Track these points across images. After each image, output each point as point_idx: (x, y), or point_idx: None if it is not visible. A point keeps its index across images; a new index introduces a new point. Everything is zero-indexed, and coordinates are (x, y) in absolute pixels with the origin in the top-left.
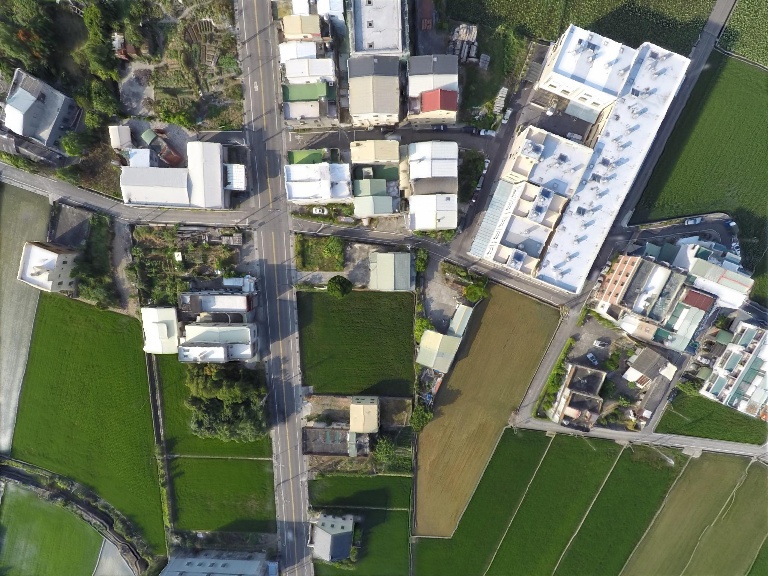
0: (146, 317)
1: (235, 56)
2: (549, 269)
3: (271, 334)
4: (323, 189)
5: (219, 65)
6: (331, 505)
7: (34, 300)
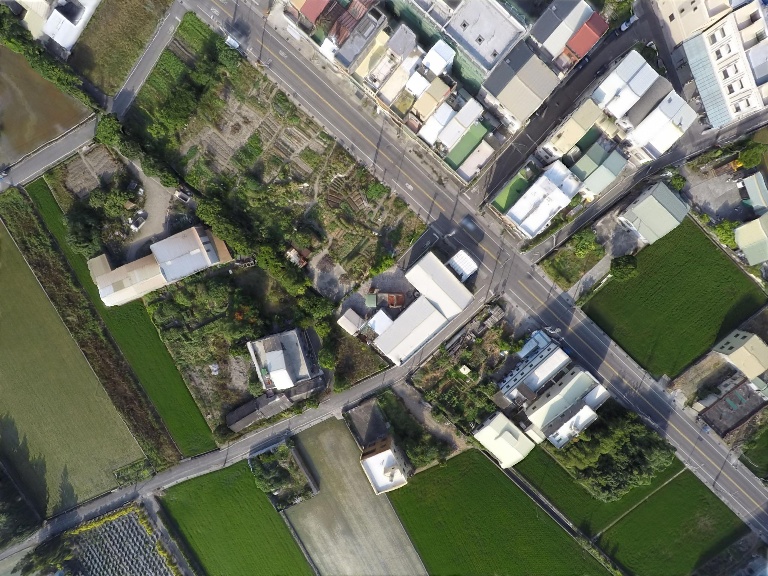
0: (484, 440)
1: (376, 182)
2: None
3: (590, 363)
4: (559, 199)
5: (370, 200)
6: None
7: (385, 503)
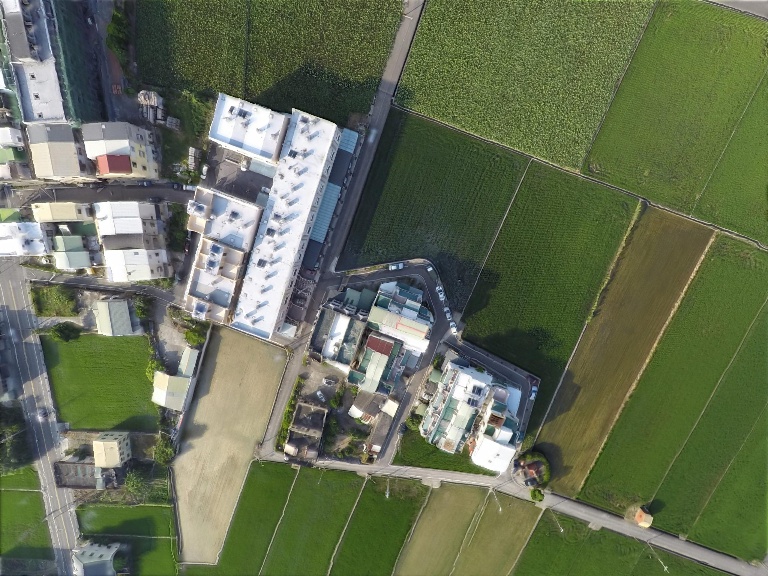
0: None
1: None
2: (243, 317)
3: (22, 375)
4: (16, 247)
5: None
6: (101, 533)
7: None
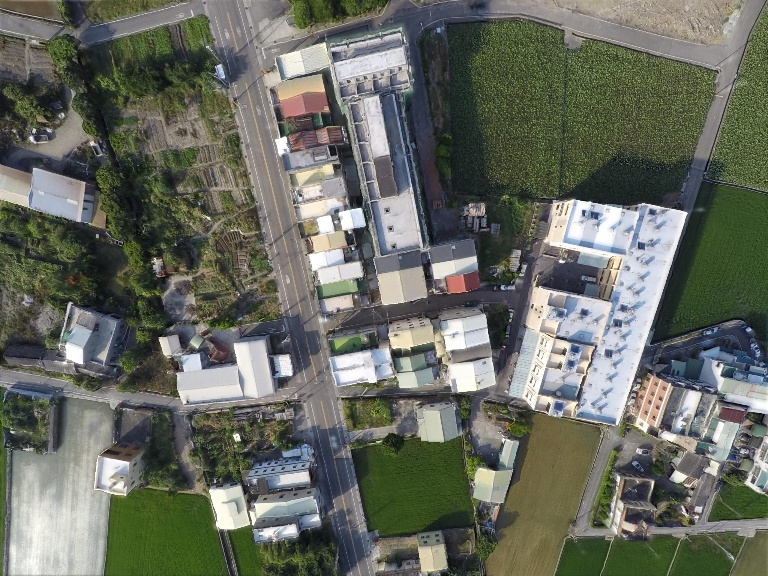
0: (215, 497)
1: (265, 257)
2: (587, 406)
3: (332, 490)
4: (369, 375)
5: (251, 266)
6: None
7: (107, 494)
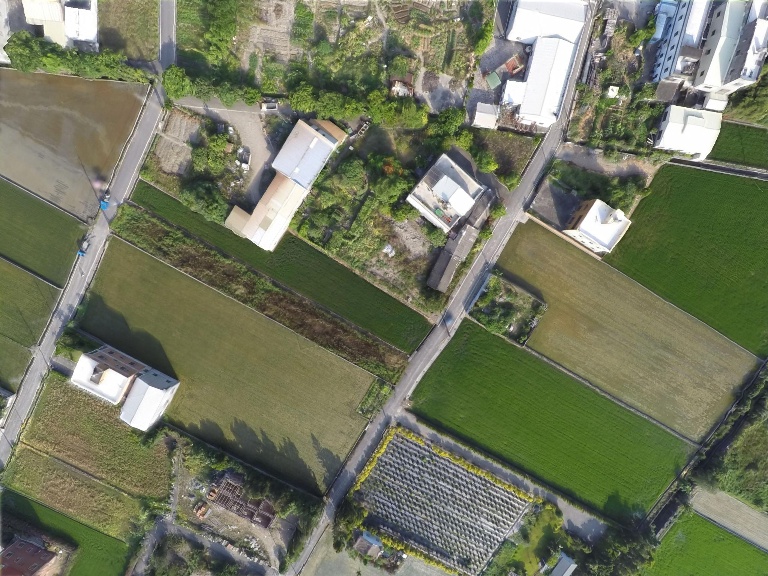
0: (670, 143)
1: None
2: None
3: None
4: None
5: None
6: None
7: (612, 274)
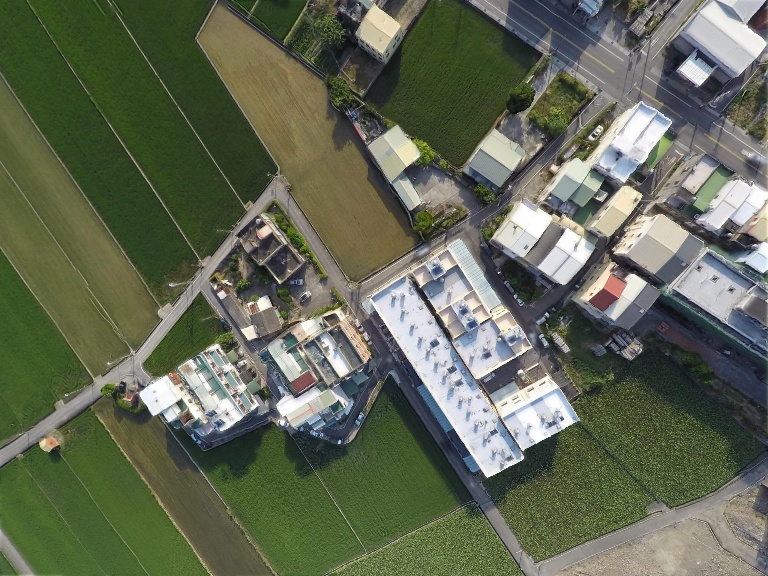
0: None
1: None
2: (405, 291)
3: None
4: (625, 142)
5: None
6: None
7: None
